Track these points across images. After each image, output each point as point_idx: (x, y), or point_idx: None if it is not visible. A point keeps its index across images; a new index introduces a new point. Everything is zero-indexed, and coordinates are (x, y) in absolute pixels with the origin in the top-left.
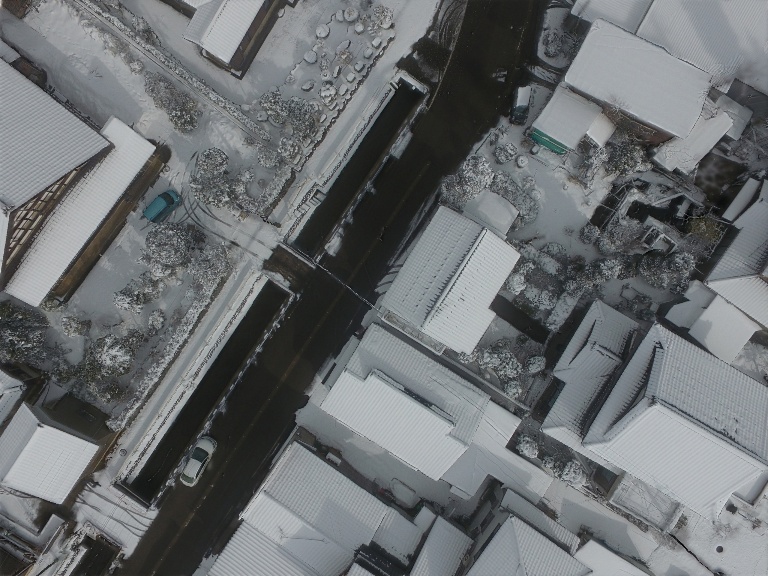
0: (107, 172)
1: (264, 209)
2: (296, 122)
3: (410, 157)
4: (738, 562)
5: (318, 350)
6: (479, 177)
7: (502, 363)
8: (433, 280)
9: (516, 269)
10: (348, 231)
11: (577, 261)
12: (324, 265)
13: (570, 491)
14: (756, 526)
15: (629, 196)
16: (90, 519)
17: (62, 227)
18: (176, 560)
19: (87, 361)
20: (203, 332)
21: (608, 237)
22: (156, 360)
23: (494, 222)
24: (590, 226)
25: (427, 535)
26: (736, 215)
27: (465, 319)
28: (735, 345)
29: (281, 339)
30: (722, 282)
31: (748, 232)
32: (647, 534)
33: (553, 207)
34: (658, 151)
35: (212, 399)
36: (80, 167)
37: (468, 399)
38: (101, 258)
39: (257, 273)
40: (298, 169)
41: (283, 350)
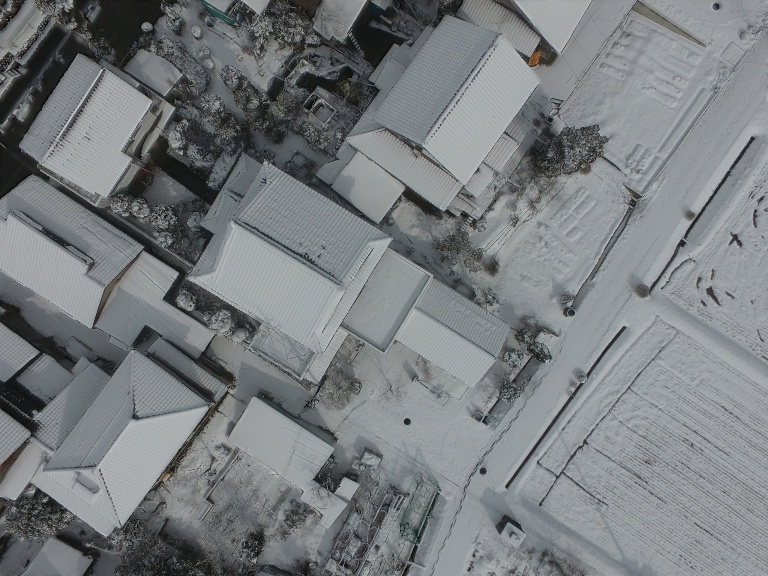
0: None
1: None
2: None
3: None
4: (426, 435)
5: None
6: None
7: (154, 214)
8: (59, 119)
9: None
10: (37, 98)
11: (246, 126)
12: (13, 130)
13: (249, 355)
14: (438, 397)
15: (299, 67)
16: None
17: None
18: None
19: None
20: None
21: (276, 104)
22: None
23: (155, 82)
24: None
25: None
26: None
27: (93, 159)
28: (382, 203)
29: None
30: (358, 137)
31: (384, 91)
32: None
33: None
34: (315, 20)
35: None
36: None
37: (117, 246)
38: None
39: None
40: None
41: None
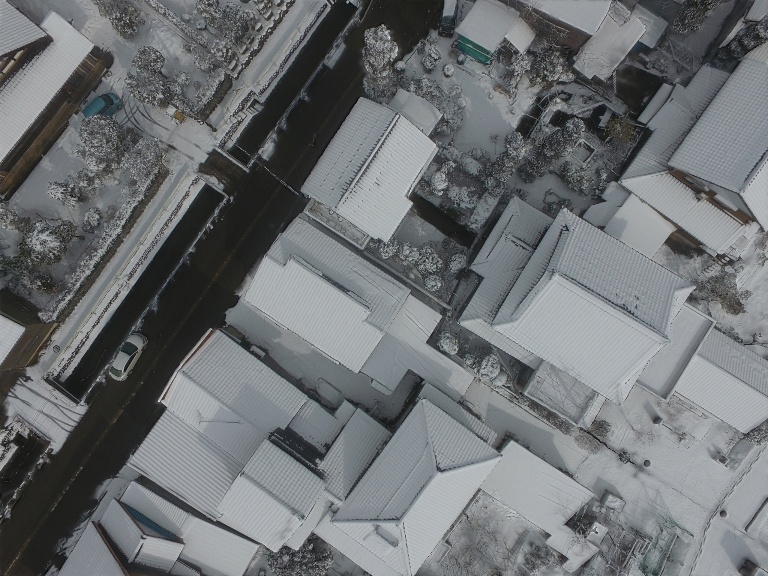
0: (45, 65)
1: (198, 109)
2: (227, 22)
3: (343, 67)
4: (666, 477)
5: (249, 251)
6: (379, 43)
7: (422, 257)
8: (349, 164)
9: (438, 168)
10: (281, 137)
11: None
12: (257, 169)
13: (495, 397)
14: (682, 439)
15: (552, 105)
16: (21, 413)
17: (0, 116)
18: (104, 456)
19: (18, 245)
20: (138, 232)
21: (531, 143)
22: (89, 253)
23: None
24: (513, 132)
25: (345, 425)
26: (650, 118)
27: (380, 204)
28: (651, 245)
29: (214, 240)
30: (635, 179)
31: (660, 132)
32: (572, 443)
33: (479, 115)
34: (577, 59)
35: (148, 302)
36: (18, 56)
37: (387, 290)
38: (43, 158)
39: (193, 176)
40: (234, 76)
41: (215, 251)
